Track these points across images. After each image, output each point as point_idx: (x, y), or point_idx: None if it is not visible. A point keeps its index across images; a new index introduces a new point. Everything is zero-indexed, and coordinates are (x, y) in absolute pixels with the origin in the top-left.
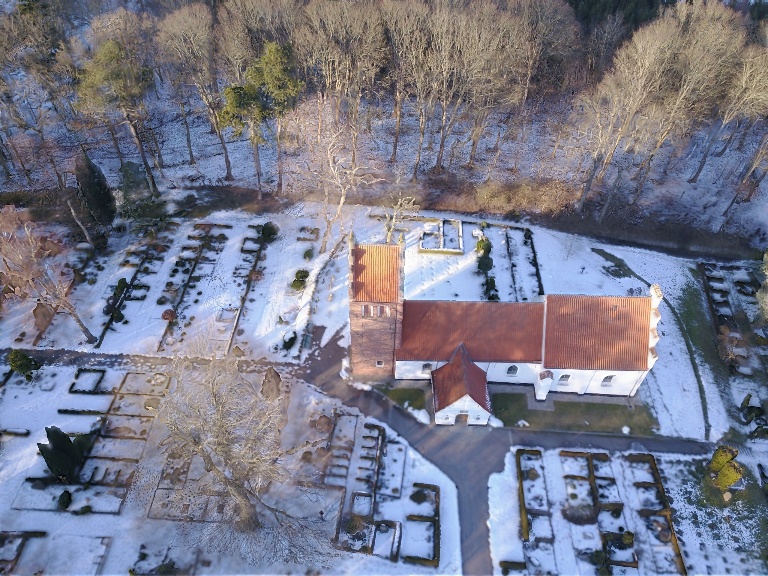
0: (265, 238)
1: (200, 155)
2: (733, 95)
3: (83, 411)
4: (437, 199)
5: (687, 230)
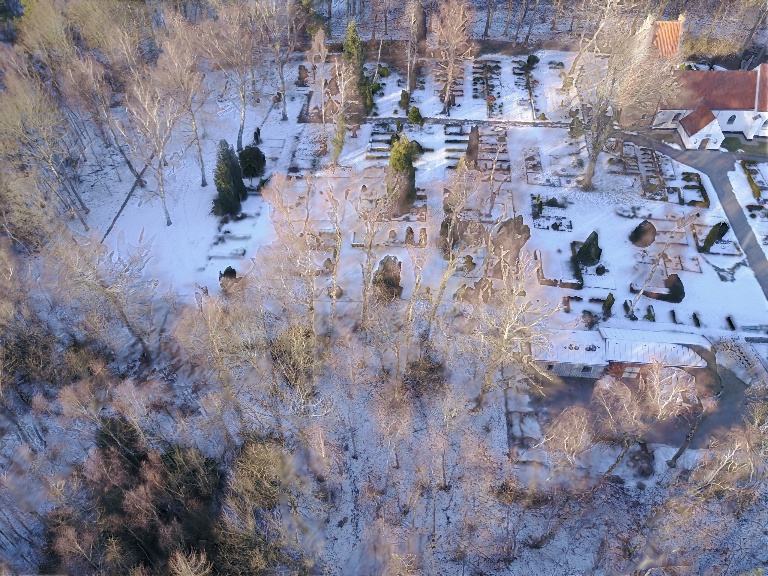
0: (527, 67)
1: None
2: None
3: (462, 140)
4: None
5: None
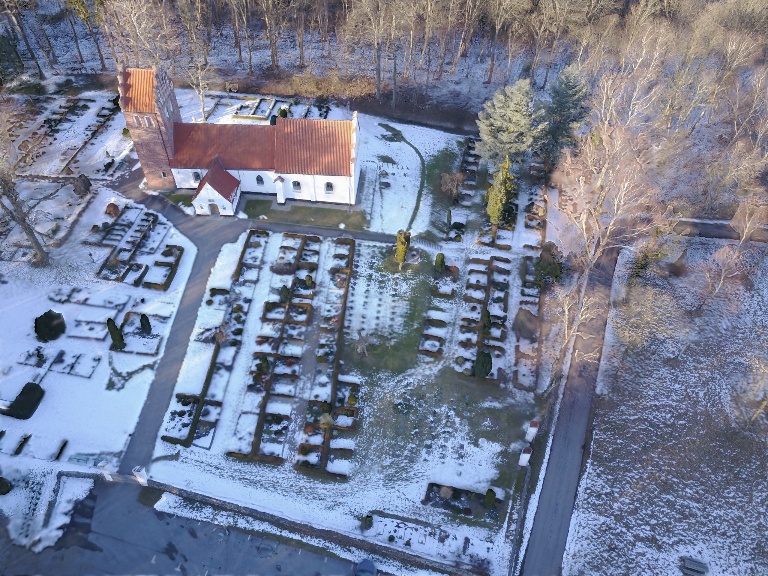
0: (118, 108)
1: (91, 58)
2: (491, 1)
3: None
4: None
5: (461, 113)
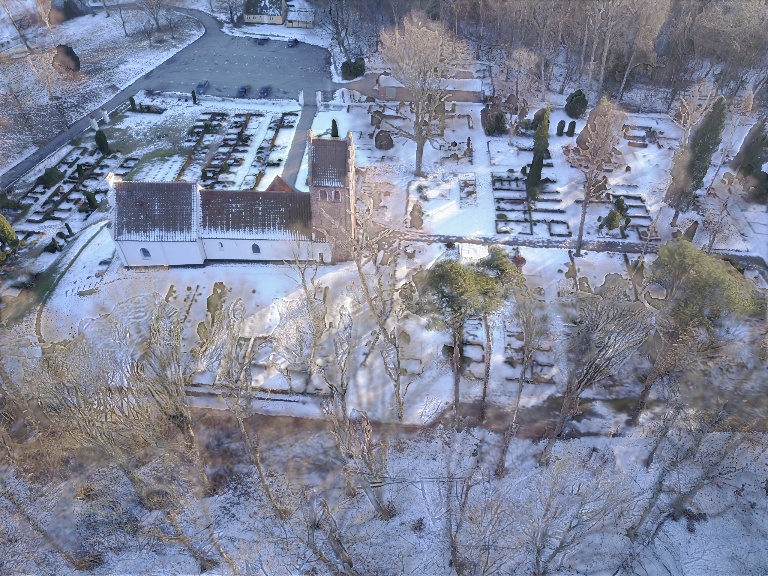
0: None
1: (637, 571)
2: None
3: (546, 209)
4: (233, 430)
5: None
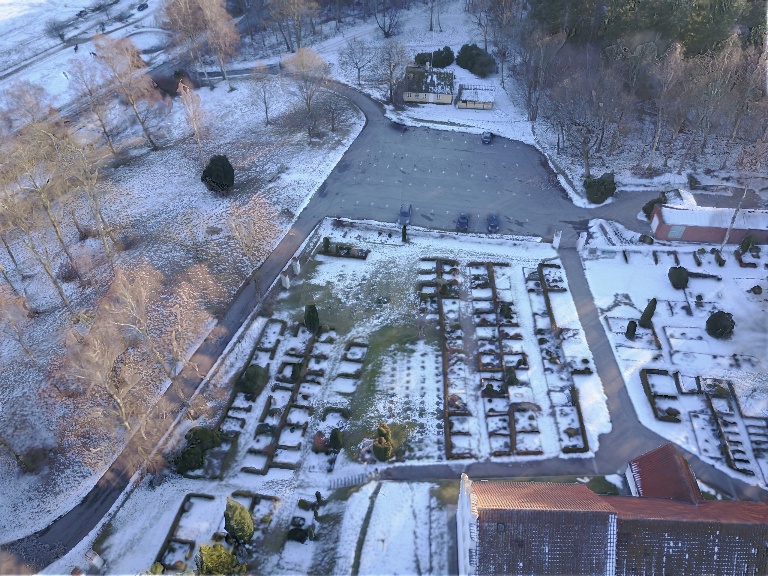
0: None
1: None
2: None
3: None
4: None
5: None
